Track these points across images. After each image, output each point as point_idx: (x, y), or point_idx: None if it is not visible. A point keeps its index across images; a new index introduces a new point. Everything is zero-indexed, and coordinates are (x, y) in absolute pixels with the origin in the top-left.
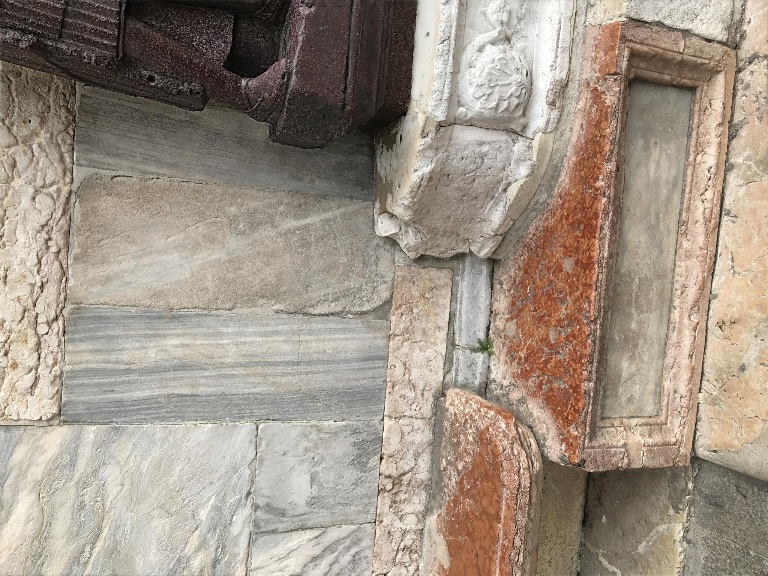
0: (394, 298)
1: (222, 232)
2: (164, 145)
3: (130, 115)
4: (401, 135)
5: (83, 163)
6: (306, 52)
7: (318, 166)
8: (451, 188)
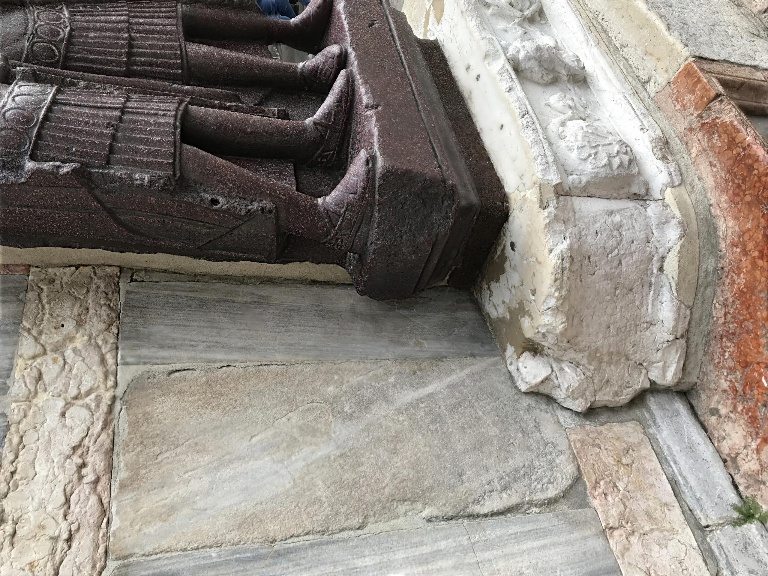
0: (583, 473)
1: (323, 420)
2: (231, 329)
3: (186, 304)
4: (511, 242)
5: (130, 361)
6: (385, 138)
7: (421, 328)
8: (598, 277)
